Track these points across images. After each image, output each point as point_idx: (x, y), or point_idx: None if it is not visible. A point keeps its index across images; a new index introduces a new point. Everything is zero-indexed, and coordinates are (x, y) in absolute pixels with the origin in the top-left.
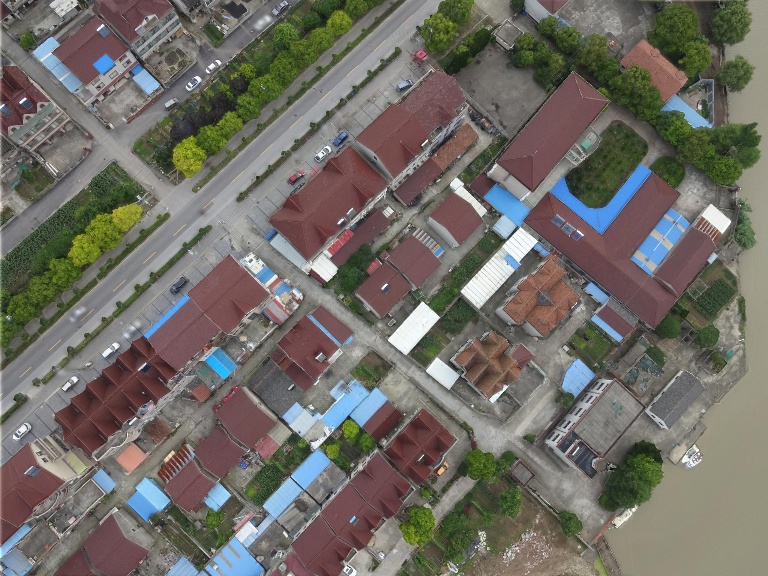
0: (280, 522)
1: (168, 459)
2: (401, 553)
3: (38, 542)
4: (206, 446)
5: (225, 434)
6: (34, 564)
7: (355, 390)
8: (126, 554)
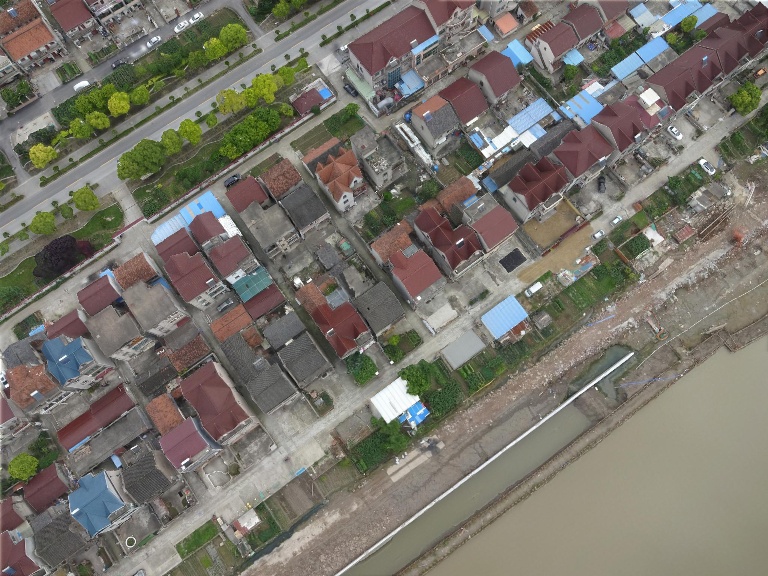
0: (624, 83)
1: (535, 29)
2: (721, 131)
3: (430, 68)
4: (573, 14)
5: (590, 6)
6: (423, 85)
7: (691, 2)
8: (506, 74)
